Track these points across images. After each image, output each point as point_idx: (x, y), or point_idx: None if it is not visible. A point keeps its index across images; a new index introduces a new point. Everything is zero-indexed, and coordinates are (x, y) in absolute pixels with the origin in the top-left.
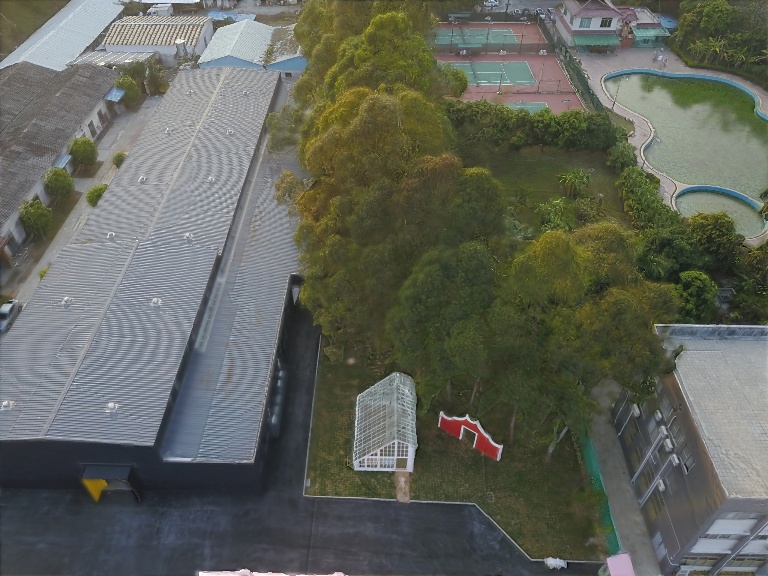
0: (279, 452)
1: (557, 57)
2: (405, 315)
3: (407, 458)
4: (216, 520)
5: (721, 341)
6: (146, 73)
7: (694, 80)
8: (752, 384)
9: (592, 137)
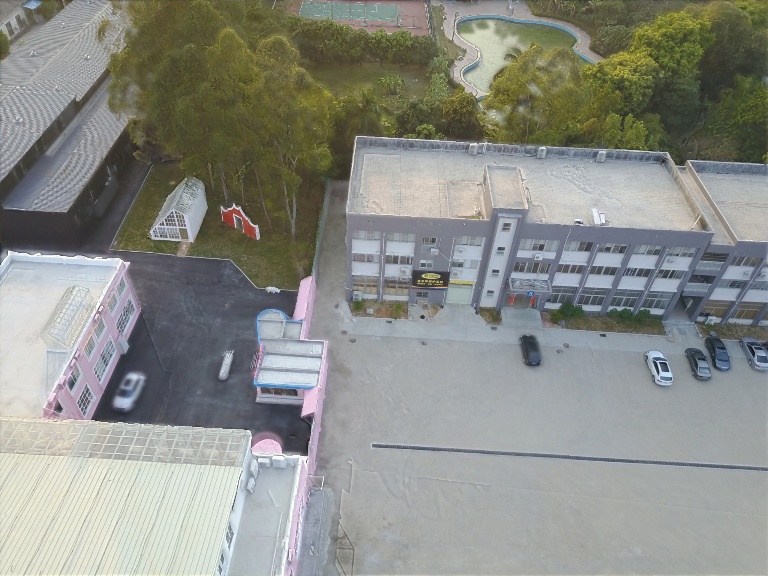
0: (99, 226)
1: (425, 2)
2: (155, 97)
3: (186, 229)
4: None
5: (404, 151)
6: None
7: (535, 25)
8: (409, 171)
9: (416, 53)
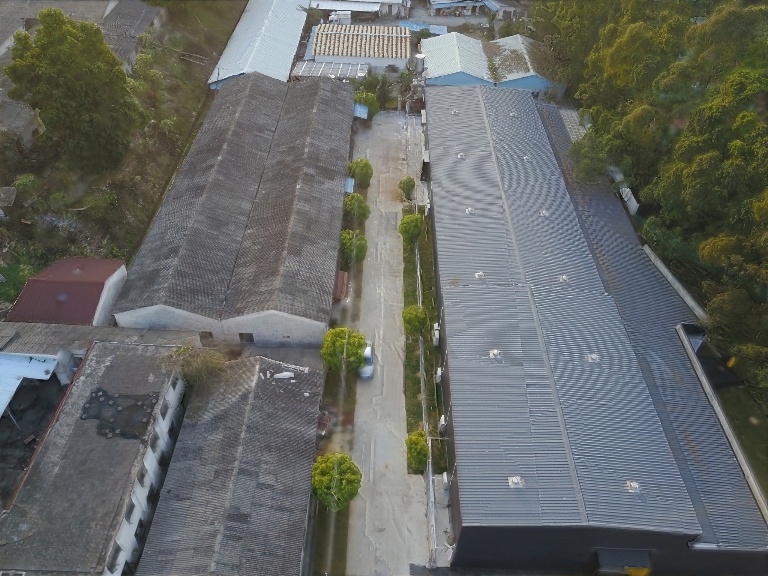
0: None
1: None
2: None
3: None
4: None
5: None
6: (377, 88)
7: None
8: None
9: None
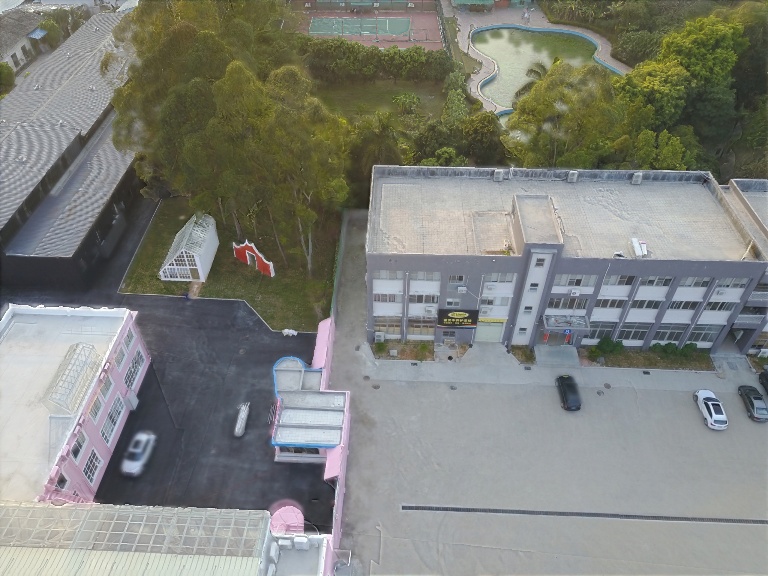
0: (107, 268)
1: (438, 14)
2: (160, 135)
3: (197, 268)
4: (48, 304)
5: (424, 179)
6: (69, 19)
7: (552, 33)
8: (431, 202)
9: (431, 69)
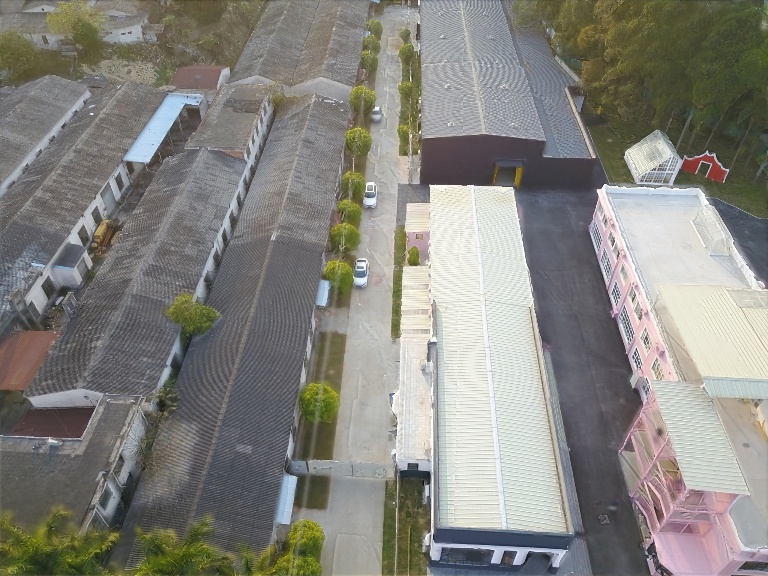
0: None
1: None
2: (708, 54)
3: (673, 173)
4: (567, 198)
5: None
6: None
7: None
8: None
9: None
